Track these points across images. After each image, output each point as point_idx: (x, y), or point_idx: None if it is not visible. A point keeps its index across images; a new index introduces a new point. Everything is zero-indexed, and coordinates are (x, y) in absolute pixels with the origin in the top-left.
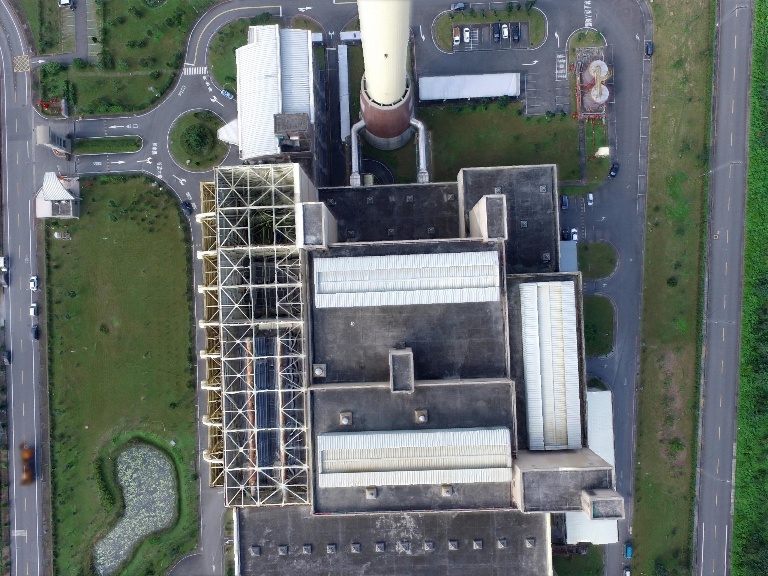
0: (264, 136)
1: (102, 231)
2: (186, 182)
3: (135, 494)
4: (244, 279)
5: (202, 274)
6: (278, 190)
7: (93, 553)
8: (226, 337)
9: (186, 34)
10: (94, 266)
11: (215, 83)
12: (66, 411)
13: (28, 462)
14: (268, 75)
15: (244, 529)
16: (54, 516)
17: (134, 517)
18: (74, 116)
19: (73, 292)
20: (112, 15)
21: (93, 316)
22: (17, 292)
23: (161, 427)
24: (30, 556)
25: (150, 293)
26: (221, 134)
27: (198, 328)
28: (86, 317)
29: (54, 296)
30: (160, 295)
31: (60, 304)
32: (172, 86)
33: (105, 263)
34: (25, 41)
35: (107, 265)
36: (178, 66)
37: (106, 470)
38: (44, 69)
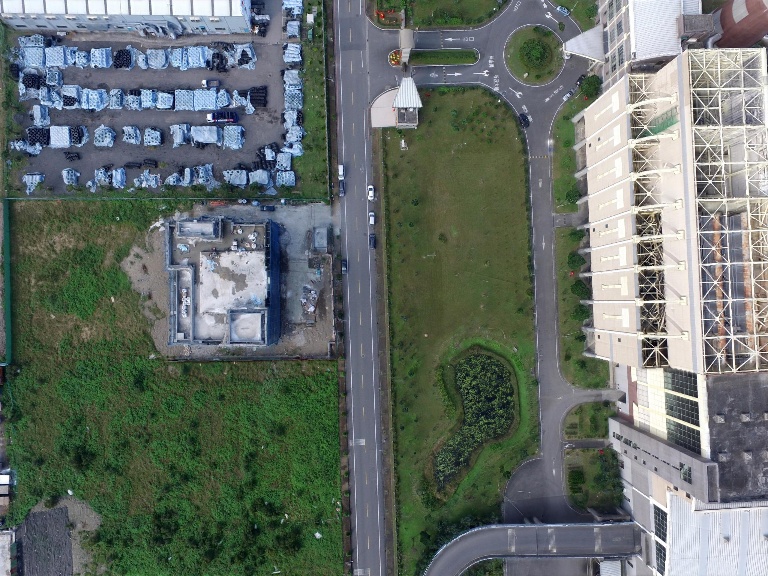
0: (666, 37)
1: (439, 141)
2: (522, 95)
3: (474, 401)
4: (716, 157)
5: (539, 185)
6: (746, 73)
7: (434, 460)
8: (701, 212)
9: None
10: (431, 176)
11: None
12: None
13: (366, 371)
14: None
15: (709, 398)
16: (395, 424)
17: (473, 424)
18: (409, 27)
19: (417, 200)
20: None
21: (431, 225)
22: (353, 201)
23: (501, 334)
24: (369, 465)
25: (488, 203)
26: (569, 46)
27: (535, 238)
28: (424, 226)
29: (391, 205)
30: (498, 205)
31: (398, 213)
32: (508, 1)
33: (443, 173)
34: None
35: (445, 175)
36: None
37: (446, 378)
38: None
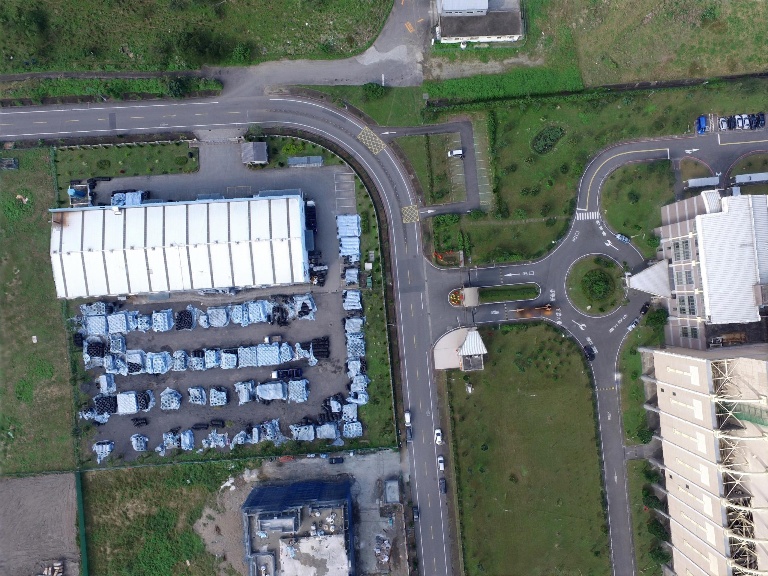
0: (742, 304)
1: (505, 380)
2: (586, 327)
3: None
4: None
5: (608, 418)
6: None
7: None
8: None
9: (578, 180)
10: (498, 416)
11: (608, 227)
12: (481, 564)
13: None
14: (743, 244)
15: None
16: None
17: None
18: (468, 265)
19: (486, 445)
20: (502, 163)
21: (501, 466)
22: (421, 446)
23: (578, 573)
24: None
25: (557, 440)
26: (634, 283)
27: (607, 472)
28: (494, 467)
29: (459, 448)
30: (568, 441)
31: (466, 456)
32: (566, 232)
33: (510, 412)
34: (413, 191)
35: (512, 414)
36: (572, 212)
37: None
38: (438, 220)
